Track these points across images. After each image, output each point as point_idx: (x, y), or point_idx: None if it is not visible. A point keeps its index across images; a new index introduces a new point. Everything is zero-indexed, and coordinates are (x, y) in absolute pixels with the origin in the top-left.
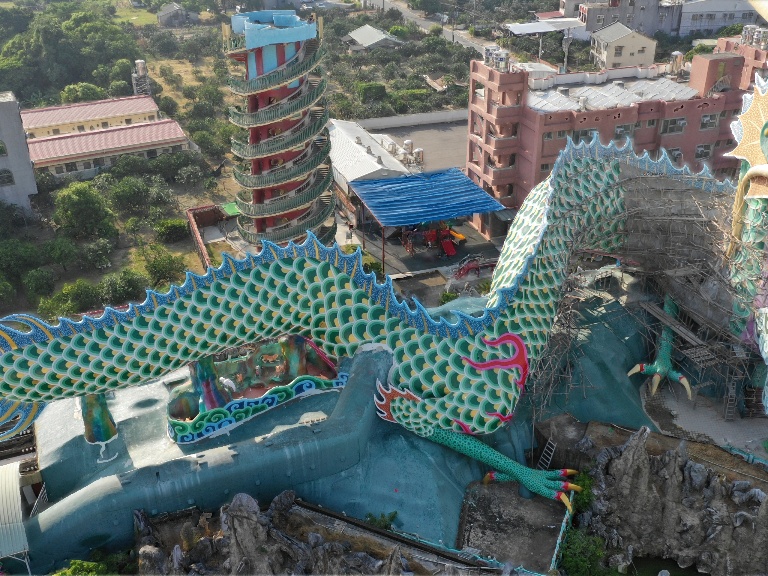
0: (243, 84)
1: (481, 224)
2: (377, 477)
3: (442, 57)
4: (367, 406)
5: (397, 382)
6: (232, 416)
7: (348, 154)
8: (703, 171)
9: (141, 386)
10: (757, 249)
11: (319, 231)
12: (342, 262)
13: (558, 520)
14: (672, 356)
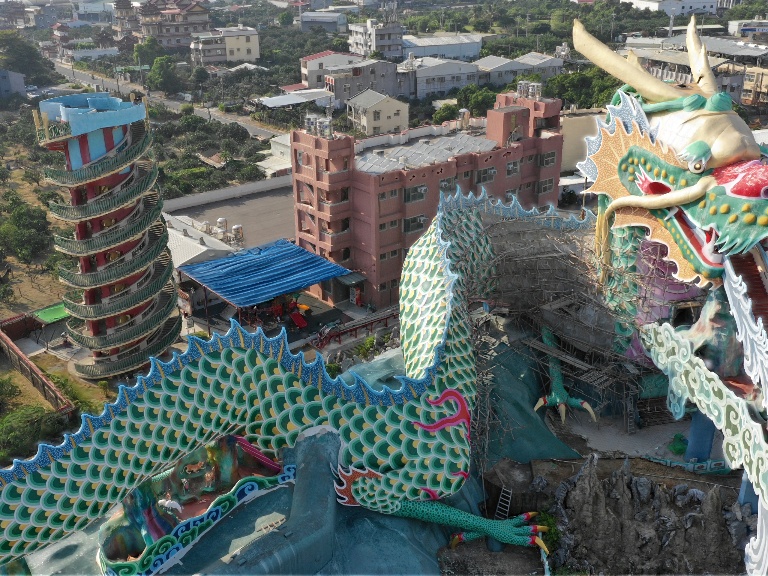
0: (70, 174)
1: (322, 292)
2: (356, 569)
3: (207, 134)
4: (329, 495)
5: (349, 463)
6: (179, 542)
7: None
8: (550, 211)
9: None
10: (631, 272)
11: (163, 324)
12: (267, 347)
13: (536, 565)
14: (564, 385)
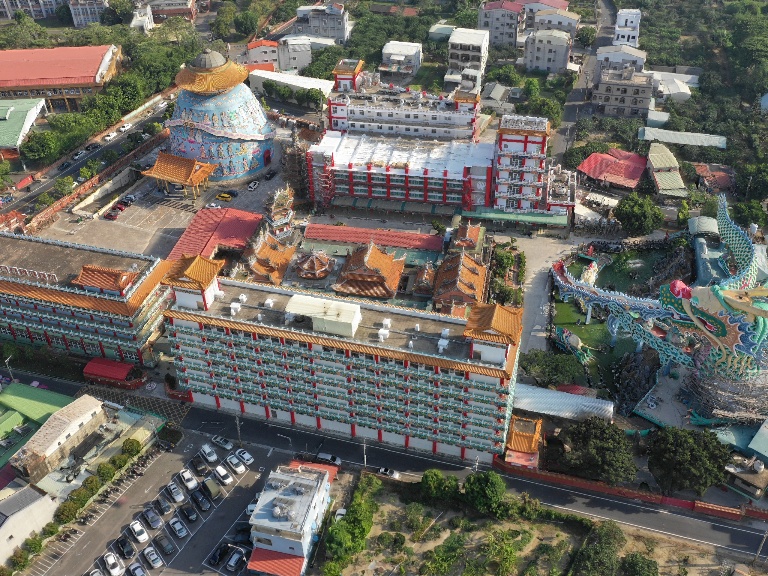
0: None
1: None
2: None
3: None
4: None
5: None
6: None
7: None
8: None
9: None
10: None
11: None
12: None
13: None
14: None
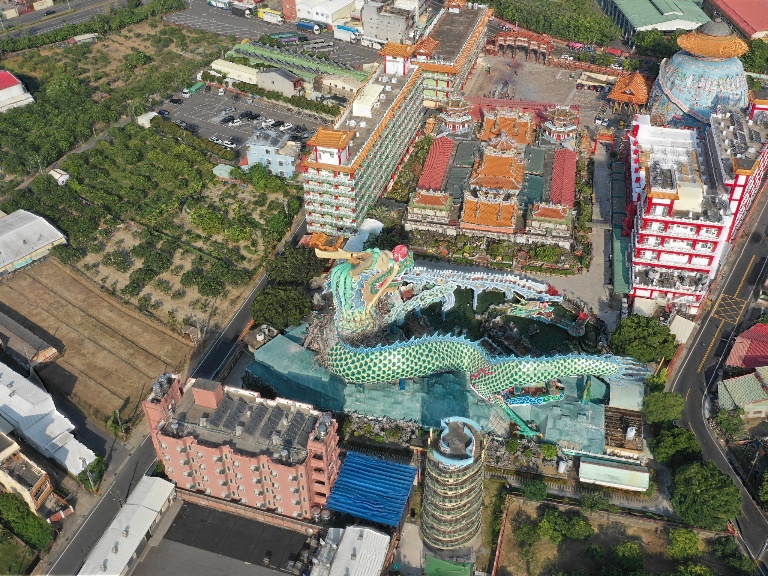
0: None
1: None
2: None
3: None
4: None
5: None
6: None
7: (366, 567)
8: None
9: (568, 415)
10: (378, 313)
11: None
12: None
13: None
14: None
